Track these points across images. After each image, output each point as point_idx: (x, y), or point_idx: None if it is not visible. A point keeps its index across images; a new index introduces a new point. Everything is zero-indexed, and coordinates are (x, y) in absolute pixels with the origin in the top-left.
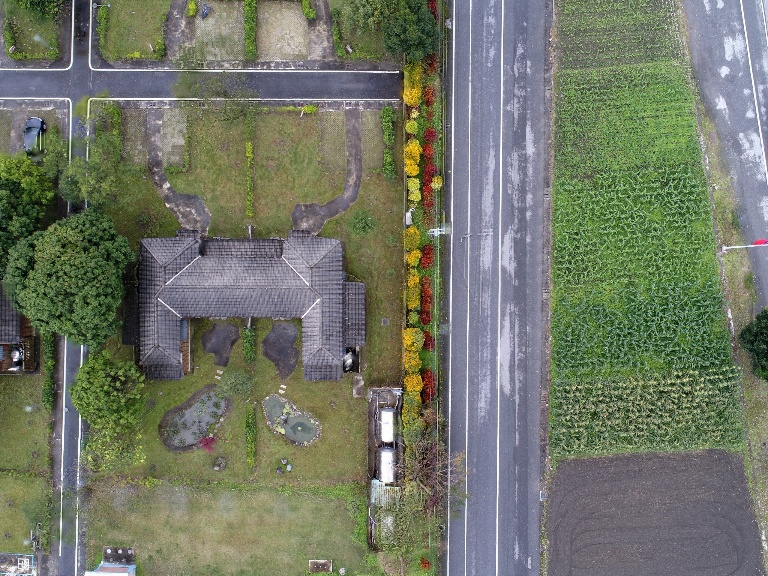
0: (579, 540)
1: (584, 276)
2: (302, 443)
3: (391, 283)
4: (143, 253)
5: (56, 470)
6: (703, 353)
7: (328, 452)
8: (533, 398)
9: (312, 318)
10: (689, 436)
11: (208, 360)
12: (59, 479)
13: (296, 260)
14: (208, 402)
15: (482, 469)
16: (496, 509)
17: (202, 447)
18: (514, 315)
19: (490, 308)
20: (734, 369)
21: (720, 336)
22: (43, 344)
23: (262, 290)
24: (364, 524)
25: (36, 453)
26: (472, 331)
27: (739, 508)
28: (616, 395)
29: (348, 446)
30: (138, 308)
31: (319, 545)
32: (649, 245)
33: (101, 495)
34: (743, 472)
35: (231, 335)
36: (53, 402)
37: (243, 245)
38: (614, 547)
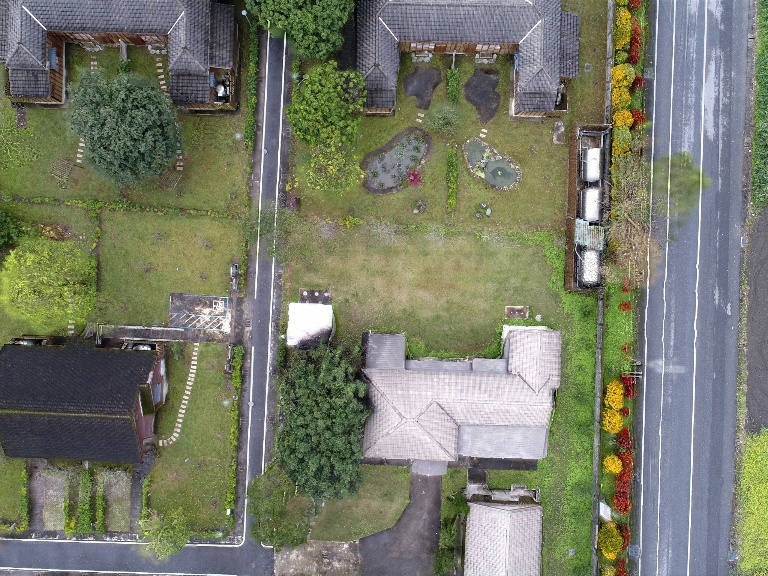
0: None
1: None
2: (502, 187)
3: (594, 29)
4: None
5: (253, 212)
6: None
7: (527, 197)
8: (736, 143)
9: (532, 41)
10: None
11: (409, 103)
12: (256, 221)
13: None
14: (408, 145)
15: (684, 213)
16: (697, 254)
17: (402, 190)
18: (719, 60)
19: (696, 52)
20: None
21: None
22: (247, 81)
23: (485, 9)
24: (562, 270)
25: (234, 194)
26: (677, 75)
27: None
28: None
29: (547, 192)
30: (355, 31)
31: (516, 291)
32: None
33: (298, 237)
34: None
35: (433, 78)
36: (254, 141)
37: None
38: None
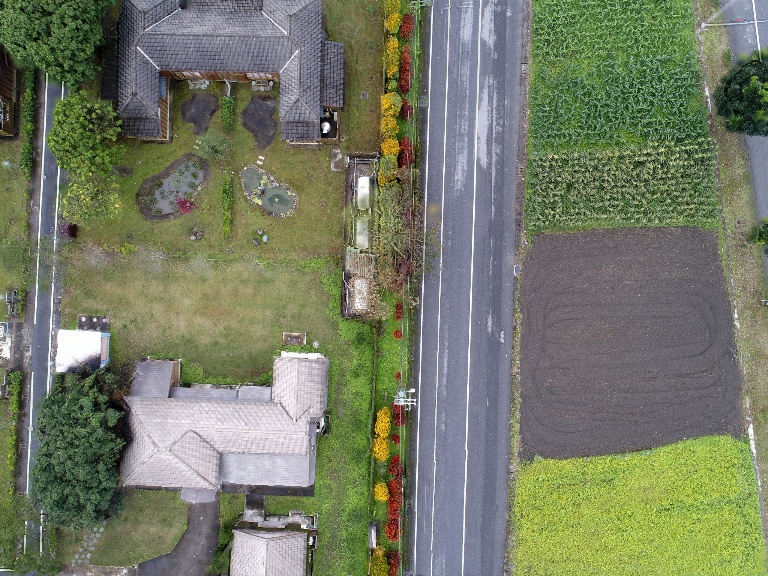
0: (552, 315)
1: (563, 48)
2: (279, 214)
3: (371, 56)
4: (123, 3)
5: (33, 238)
6: (679, 126)
7: (304, 224)
8: (510, 172)
9: (290, 71)
10: (664, 209)
11: (187, 130)
12: (36, 247)
13: (275, 12)
14: (186, 172)
15: (457, 241)
16: (470, 282)
17: (179, 216)
18: (492, 88)
19: (469, 81)
20: (710, 141)
21: (697, 110)
22: (23, 107)
23: (241, 39)
24: (339, 297)
25: (13, 220)
26: (450, 103)
27: (712, 286)
28: (592, 165)
29: (324, 219)
30: (117, 60)
31: (293, 318)
32: (628, 18)
33: (77, 263)
34: (717, 250)
35: (210, 105)
36: (31, 167)
37: (224, 3)
38: (587, 324)
